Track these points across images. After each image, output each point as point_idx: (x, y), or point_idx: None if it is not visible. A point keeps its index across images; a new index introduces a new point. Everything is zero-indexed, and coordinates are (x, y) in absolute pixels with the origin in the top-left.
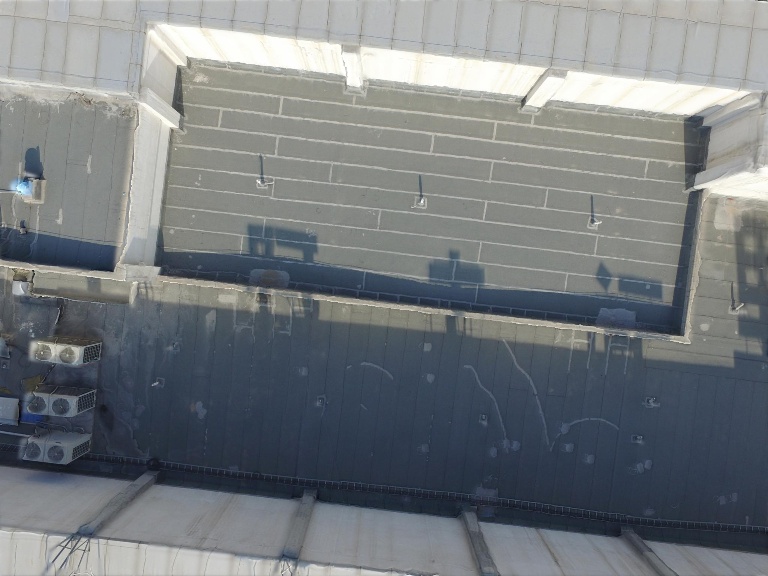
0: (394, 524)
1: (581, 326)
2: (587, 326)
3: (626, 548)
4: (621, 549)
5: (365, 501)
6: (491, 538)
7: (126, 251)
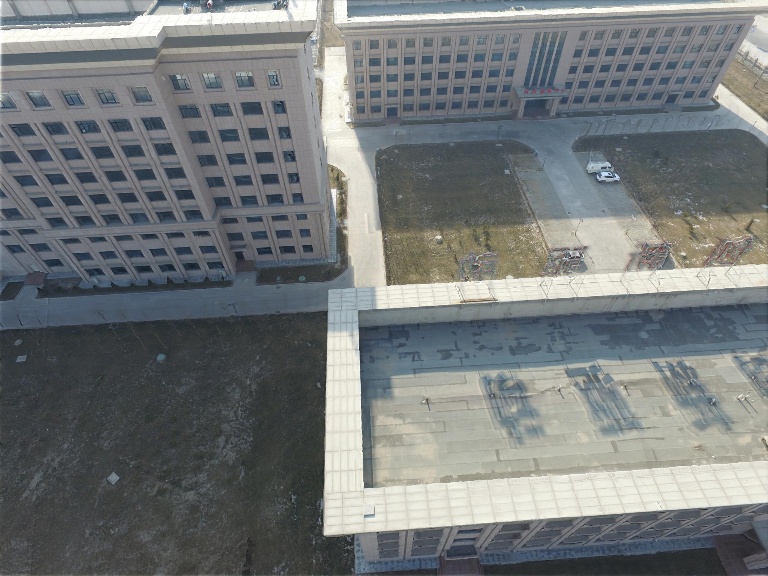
0: (99, 3)
1: (9, 26)
2: (6, 26)
3: (20, 7)
4: (22, 7)
5: (114, 15)
6: (65, 2)
7: (155, 2)
